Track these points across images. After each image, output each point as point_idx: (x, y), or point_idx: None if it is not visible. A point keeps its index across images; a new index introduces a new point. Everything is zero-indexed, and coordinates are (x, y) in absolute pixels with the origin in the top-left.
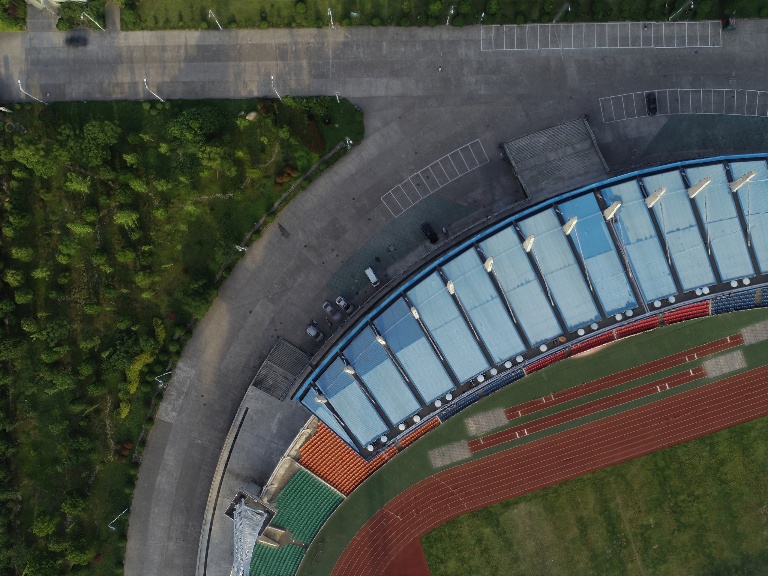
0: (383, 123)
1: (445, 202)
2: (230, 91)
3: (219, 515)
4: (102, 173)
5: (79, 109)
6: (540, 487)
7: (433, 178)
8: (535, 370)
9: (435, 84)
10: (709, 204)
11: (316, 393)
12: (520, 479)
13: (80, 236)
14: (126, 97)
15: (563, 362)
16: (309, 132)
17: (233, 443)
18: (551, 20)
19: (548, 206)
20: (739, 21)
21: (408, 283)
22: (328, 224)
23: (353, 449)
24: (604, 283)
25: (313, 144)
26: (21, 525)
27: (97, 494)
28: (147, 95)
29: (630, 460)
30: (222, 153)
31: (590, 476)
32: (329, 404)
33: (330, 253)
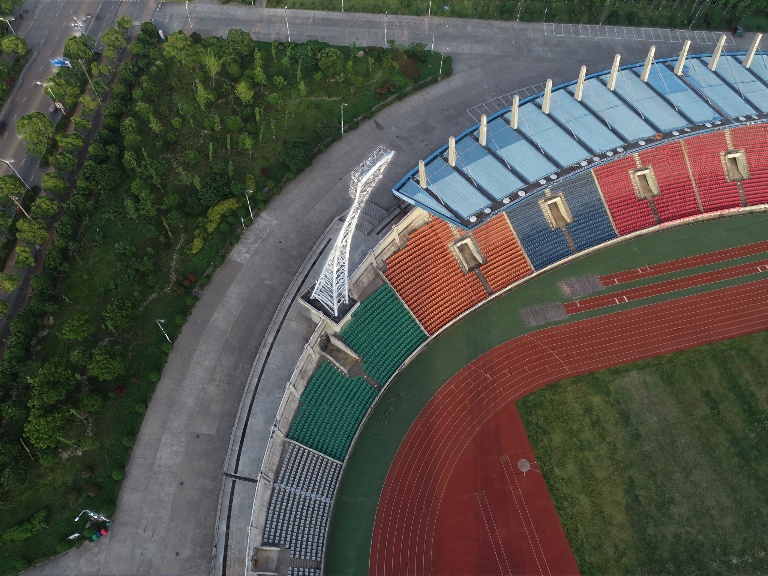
0: (468, 68)
1: None
2: (344, 42)
3: (282, 338)
4: (232, 67)
5: None
6: (652, 355)
7: None
8: (627, 232)
9: (510, 50)
10: (764, 72)
11: (415, 183)
12: (627, 345)
13: (196, 114)
14: (260, 40)
15: (653, 240)
16: (407, 64)
17: (310, 269)
18: (598, 24)
19: (624, 69)
20: (744, 34)
21: (504, 110)
22: (419, 124)
23: (454, 221)
24: (688, 106)
25: (410, 71)
26: (41, 350)
27: (141, 324)
28: (277, 40)
29: (749, 334)
30: (338, 54)
31: (707, 348)
32: (428, 190)
33: (420, 143)
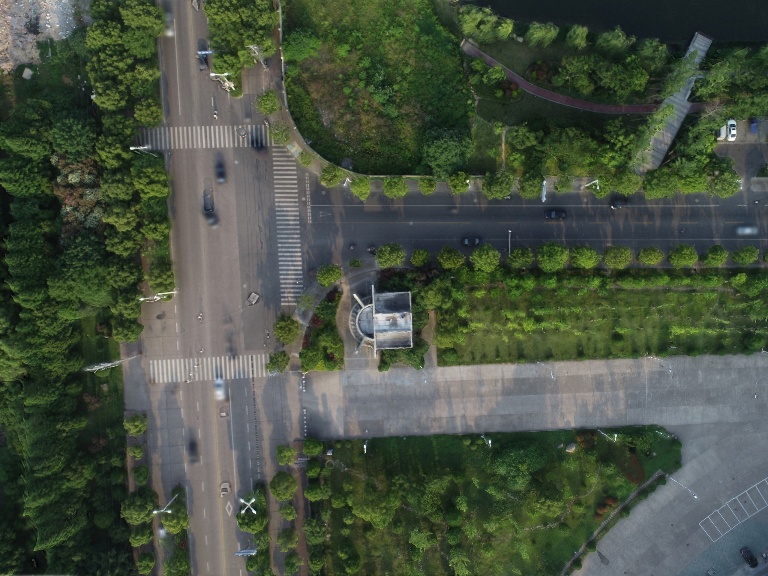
0: (700, 450)
1: (763, 526)
2: (547, 423)
3: None
4: (434, 519)
5: (399, 445)
6: None
7: (750, 503)
8: None
9: (751, 410)
10: None
11: None
12: None
13: (403, 571)
14: (444, 431)
15: None
16: (630, 465)
17: None
18: None
19: None
20: None
21: None
22: (647, 551)
23: None
24: None
25: (635, 476)
26: None
27: None
28: (465, 429)
29: None
30: None
31: None
32: None
33: None
